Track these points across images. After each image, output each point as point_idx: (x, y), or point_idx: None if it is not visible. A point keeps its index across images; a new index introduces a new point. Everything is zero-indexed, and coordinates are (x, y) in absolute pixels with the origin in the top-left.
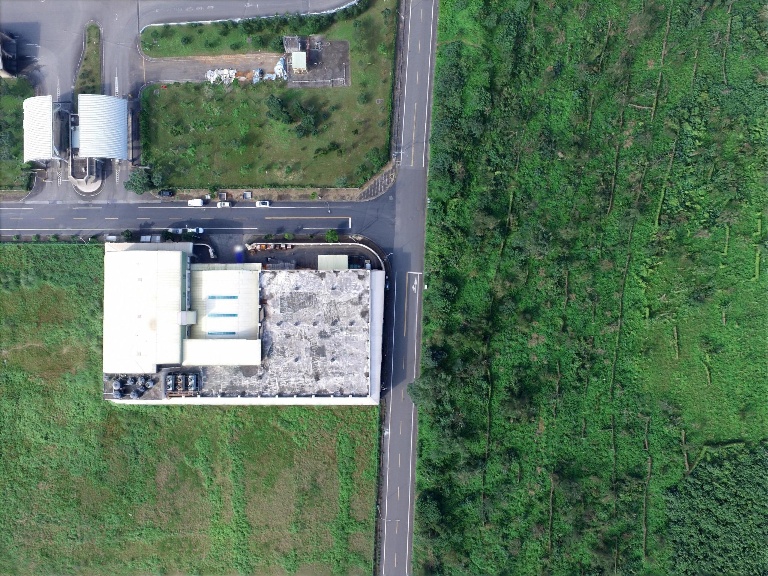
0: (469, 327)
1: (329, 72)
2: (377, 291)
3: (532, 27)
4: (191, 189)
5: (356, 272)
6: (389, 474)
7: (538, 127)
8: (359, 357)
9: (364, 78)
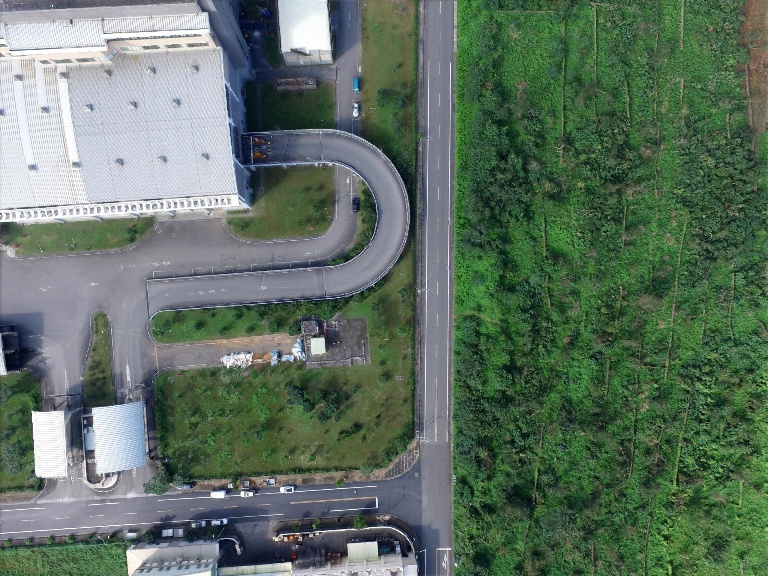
0: None
1: (348, 351)
2: None
3: (547, 297)
4: (212, 479)
5: (388, 569)
6: None
7: (558, 399)
8: None
9: (384, 355)
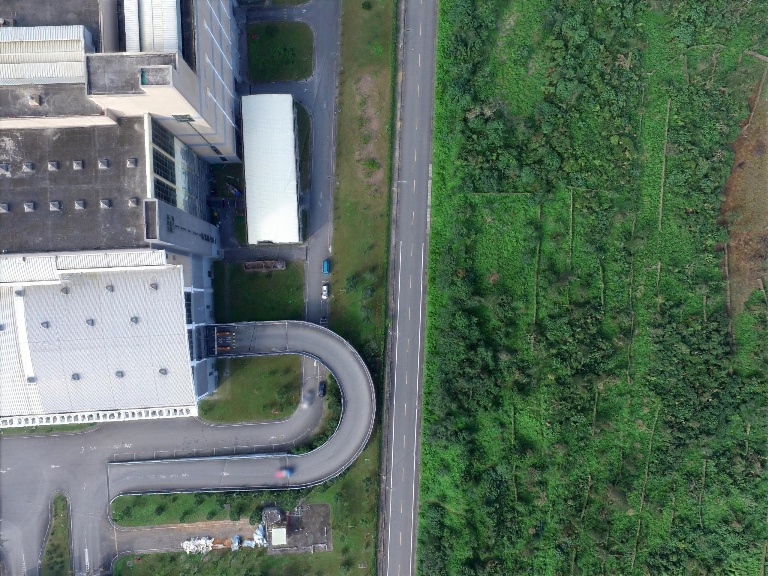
0: None
1: (310, 537)
2: None
3: (514, 486)
4: None
5: None
6: None
7: None
8: None
9: (346, 542)
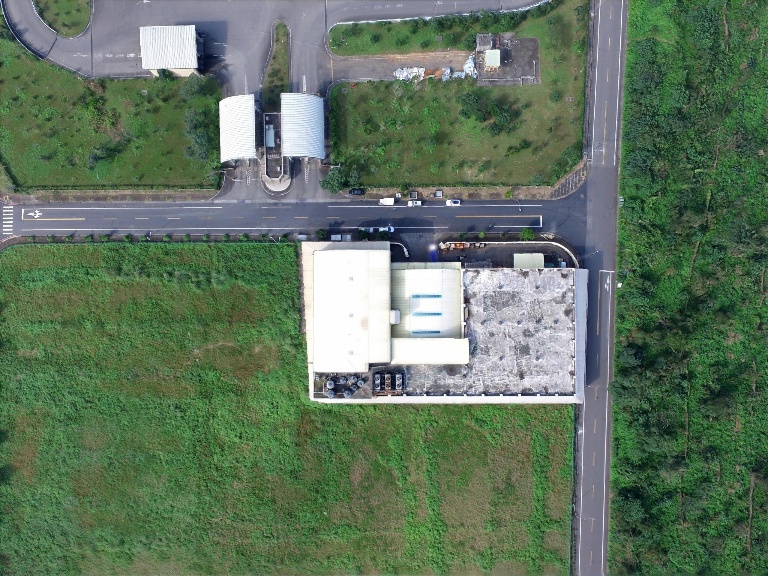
0: (665, 325)
1: (519, 70)
2: (580, 290)
3: (724, 24)
4: (382, 188)
5: (559, 271)
6: (584, 473)
7: (733, 124)
8: (563, 356)
9: (554, 76)
